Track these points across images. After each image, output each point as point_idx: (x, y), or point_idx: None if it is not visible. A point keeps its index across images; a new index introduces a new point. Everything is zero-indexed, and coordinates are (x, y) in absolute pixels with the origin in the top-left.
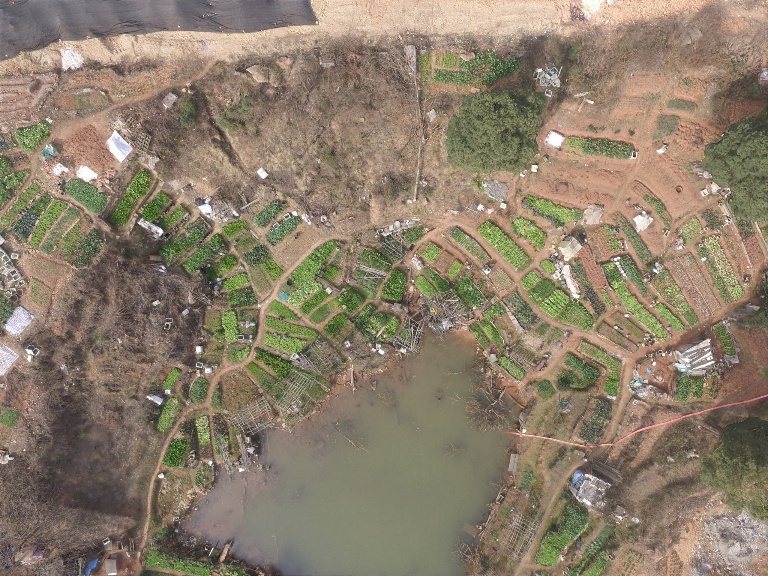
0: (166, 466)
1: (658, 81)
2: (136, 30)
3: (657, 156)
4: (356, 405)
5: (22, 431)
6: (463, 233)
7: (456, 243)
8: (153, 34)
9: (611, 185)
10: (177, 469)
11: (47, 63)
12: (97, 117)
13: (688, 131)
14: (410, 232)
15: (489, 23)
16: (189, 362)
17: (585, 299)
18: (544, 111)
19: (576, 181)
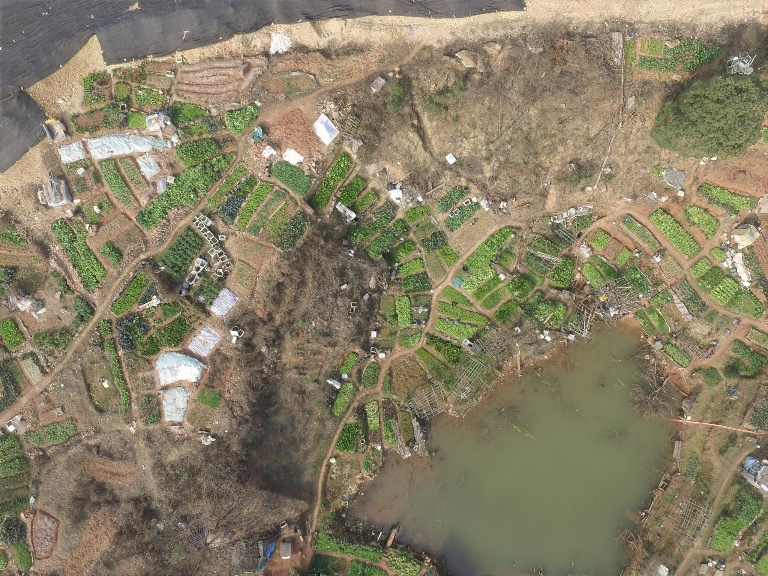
0: (337, 450)
1: None
2: (347, 14)
3: None
4: (520, 391)
5: (225, 412)
6: (635, 221)
7: (627, 231)
8: (363, 18)
9: None
10: (347, 454)
11: (256, 46)
12: (304, 100)
13: None
14: (580, 219)
15: (693, 11)
16: (364, 347)
17: (757, 287)
18: None
19: (754, 169)
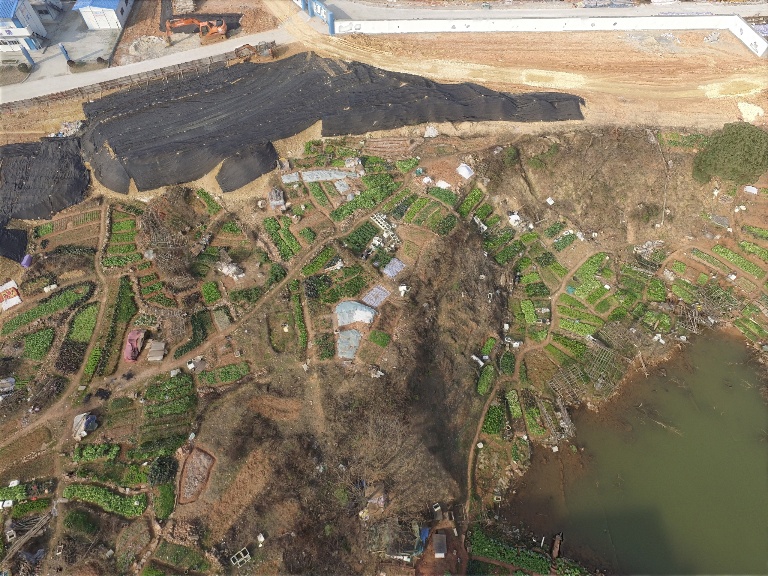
0: (483, 436)
1: None
2: (473, 120)
3: None
4: (652, 390)
5: (394, 350)
6: (701, 252)
7: (698, 259)
8: (483, 122)
9: None
10: (493, 441)
11: (416, 133)
12: (449, 158)
13: None
14: None
15: (690, 122)
16: None
17: None
18: None
19: None
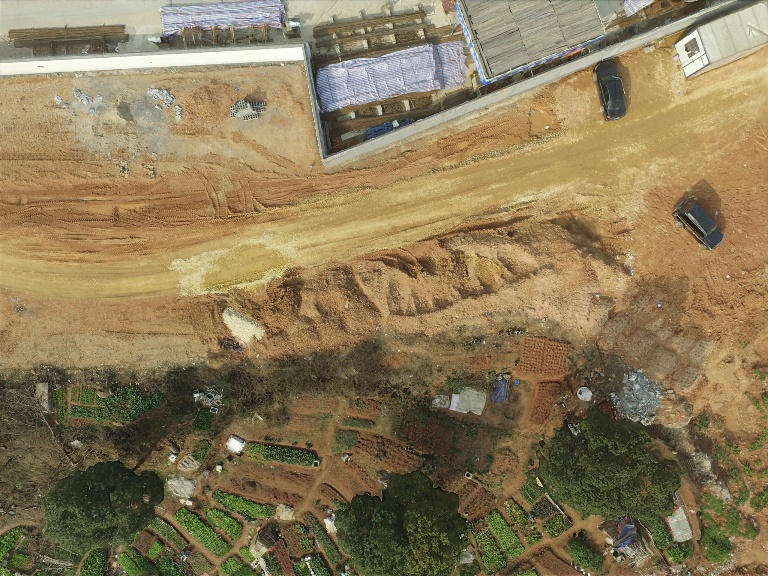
0: None
1: (327, 403)
2: None
3: (343, 463)
4: None
5: None
6: (158, 518)
7: (152, 528)
8: None
9: (299, 487)
10: None
11: None
12: None
13: (369, 444)
14: None
15: (130, 356)
16: None
17: None
18: (214, 424)
19: (264, 481)
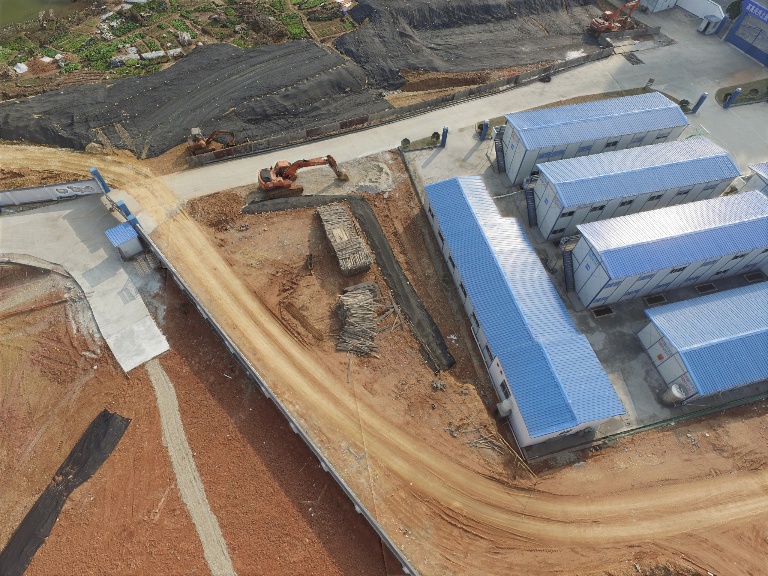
0: None
1: None
2: None
3: None
4: None
5: None
6: None
7: None
8: None
9: None
10: None
11: None
12: None
13: None
14: None
15: None
16: None
17: None
18: None
19: None
